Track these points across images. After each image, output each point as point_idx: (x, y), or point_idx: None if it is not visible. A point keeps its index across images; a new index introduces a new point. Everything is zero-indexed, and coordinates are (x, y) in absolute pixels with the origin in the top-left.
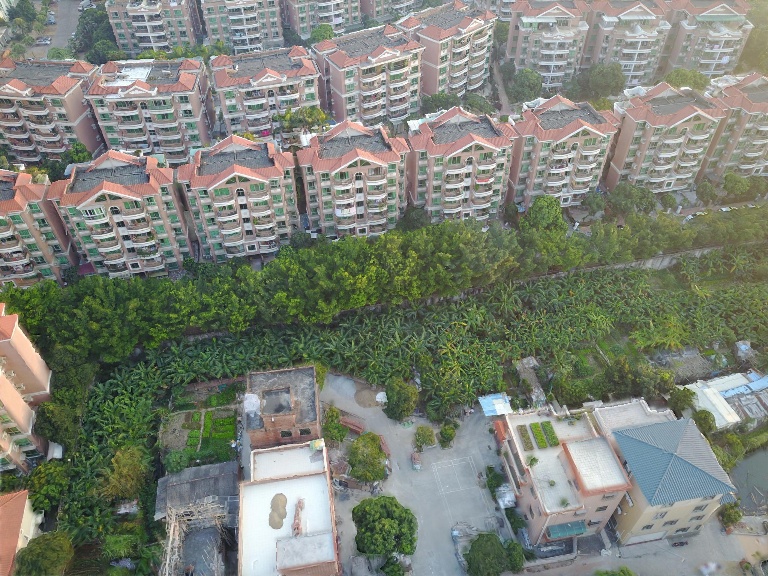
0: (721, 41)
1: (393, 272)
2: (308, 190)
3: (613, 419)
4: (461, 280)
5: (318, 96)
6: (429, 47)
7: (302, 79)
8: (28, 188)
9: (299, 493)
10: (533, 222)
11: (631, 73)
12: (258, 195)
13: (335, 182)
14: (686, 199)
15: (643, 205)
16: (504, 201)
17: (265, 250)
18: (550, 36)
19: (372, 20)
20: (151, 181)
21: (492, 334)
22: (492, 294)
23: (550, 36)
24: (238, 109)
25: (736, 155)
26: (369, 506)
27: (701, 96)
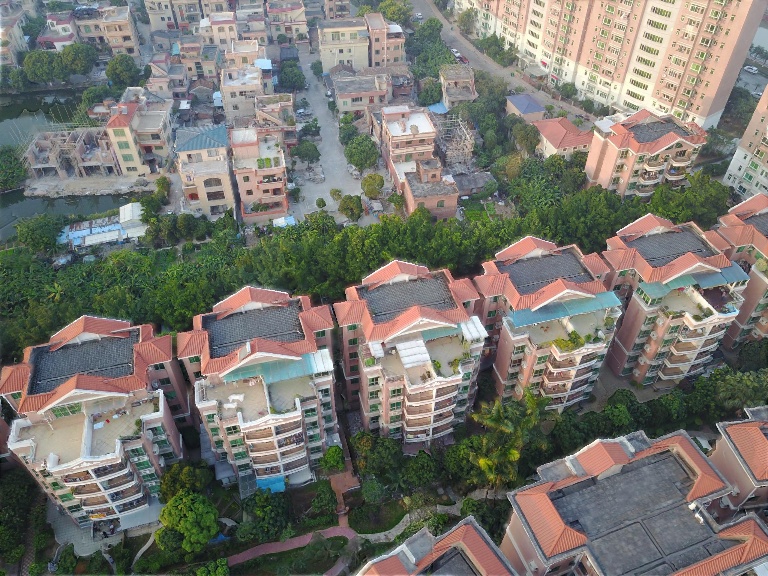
0: None
1: None
2: None
3: (218, 169)
4: None
5: None
6: None
7: None
8: (737, 226)
9: (405, 134)
10: None
11: None
12: None
13: None
14: None
15: None
16: None
17: None
18: None
19: None
20: (619, 240)
21: None
22: None
23: None
24: None
25: None
26: (369, 146)
27: None
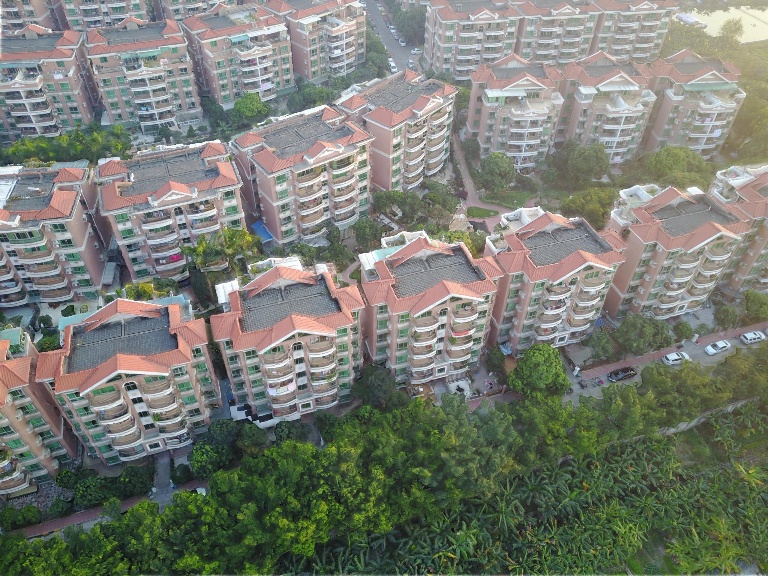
0: (713, 114)
1: (351, 505)
2: (229, 365)
3: None
4: (446, 503)
5: (243, 200)
6: (378, 133)
7: (219, 191)
8: None
9: None
10: (527, 381)
11: (613, 150)
12: (156, 390)
13: (265, 360)
14: (703, 327)
15: (657, 343)
16: (485, 343)
17: (174, 446)
18: (521, 113)
19: (307, 83)
20: None
21: (491, 570)
22: (485, 500)
23: (521, 113)
24: (135, 233)
25: (756, 268)
26: None
27: (716, 203)
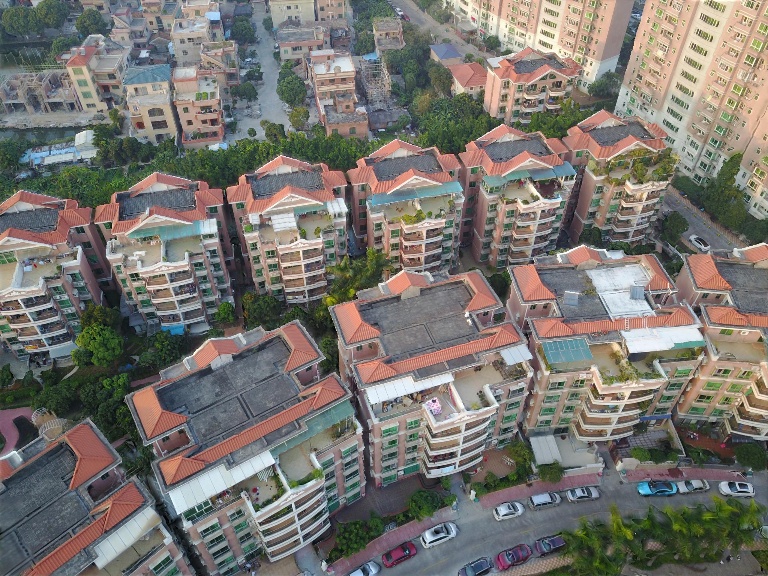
0: None
1: None
2: None
3: None
4: None
5: None
6: None
7: None
8: (576, 135)
9: None
10: None
11: None
12: None
13: None
14: None
15: None
16: None
17: None
18: None
19: None
20: (473, 144)
21: None
22: None
23: None
24: None
25: None
26: (298, 85)
27: None
